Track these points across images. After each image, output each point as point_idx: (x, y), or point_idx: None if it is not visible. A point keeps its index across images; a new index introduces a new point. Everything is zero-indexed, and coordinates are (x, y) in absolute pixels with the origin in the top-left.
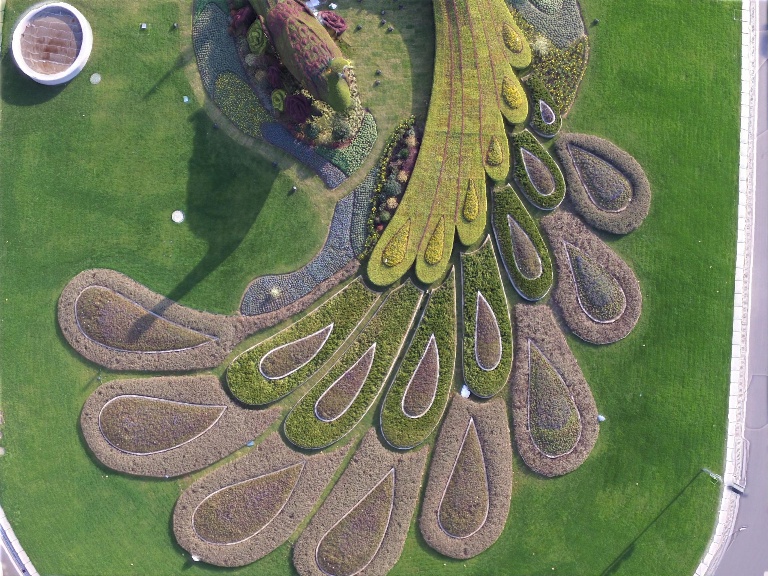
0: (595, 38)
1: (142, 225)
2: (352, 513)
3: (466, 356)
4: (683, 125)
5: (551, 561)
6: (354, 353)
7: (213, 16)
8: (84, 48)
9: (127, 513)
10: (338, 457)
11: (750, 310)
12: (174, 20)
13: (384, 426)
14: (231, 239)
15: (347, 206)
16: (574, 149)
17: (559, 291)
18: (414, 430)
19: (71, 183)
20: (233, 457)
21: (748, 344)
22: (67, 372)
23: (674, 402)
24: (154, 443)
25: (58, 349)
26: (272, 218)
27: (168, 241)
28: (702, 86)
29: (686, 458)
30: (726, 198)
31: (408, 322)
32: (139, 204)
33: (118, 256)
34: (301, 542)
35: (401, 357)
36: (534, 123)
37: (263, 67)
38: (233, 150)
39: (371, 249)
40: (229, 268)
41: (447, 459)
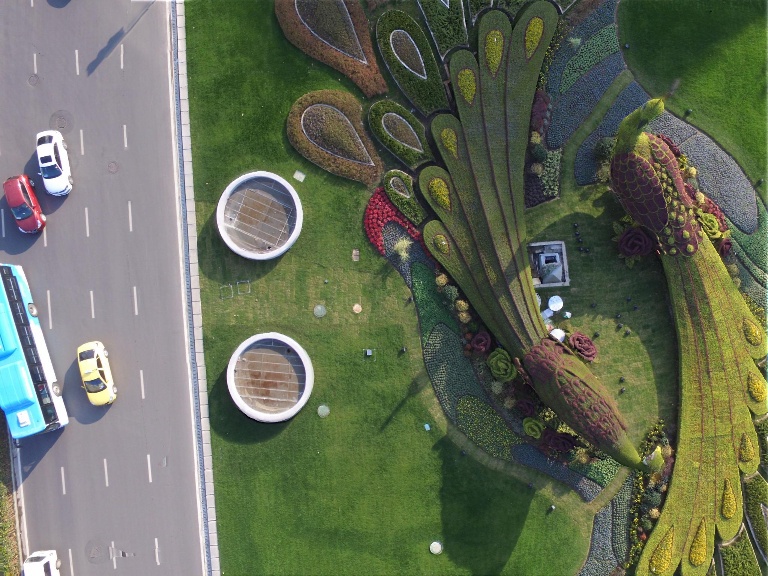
0: None
1: (400, 560)
2: None
3: None
4: None
5: None
6: None
7: (445, 339)
8: (309, 383)
9: None
10: None
11: None
12: (402, 344)
13: None
14: (494, 564)
15: (606, 517)
16: None
17: None
18: None
19: (315, 523)
20: None
21: None
22: None
23: None
24: None
25: None
26: (533, 539)
27: (429, 573)
28: None
29: None
30: None
31: None
32: (393, 540)
33: None
34: None
35: None
36: None
37: (511, 394)
38: (485, 476)
39: (636, 558)
40: None
41: None
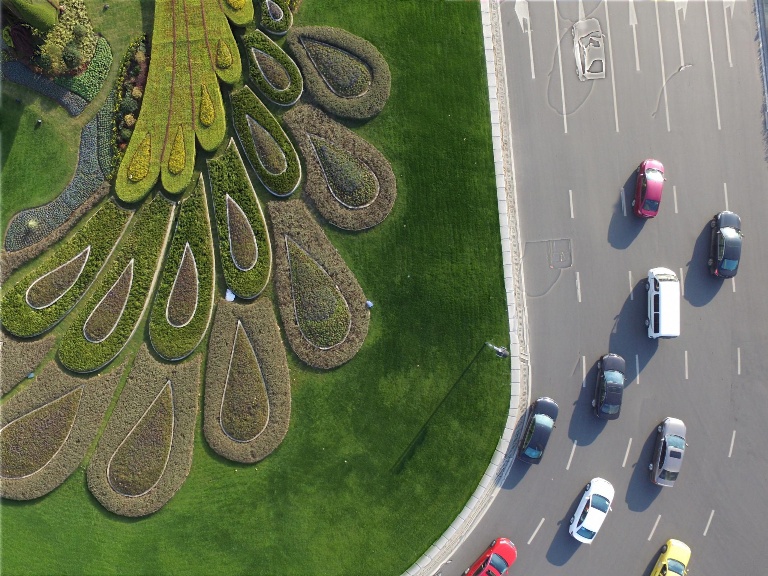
0: None
1: None
2: (135, 430)
3: (223, 259)
4: (418, 3)
5: (342, 454)
6: (113, 272)
7: None
8: None
9: None
10: (114, 377)
11: (515, 178)
12: None
13: (152, 339)
14: None
15: (91, 131)
16: (307, 42)
17: (308, 183)
18: (181, 339)
19: None
20: (17, 391)
21: (517, 212)
22: None
23: (445, 279)
24: None
25: None
26: (23, 154)
27: None
28: None
29: (466, 334)
30: (473, 69)
31: (162, 234)
32: None
33: None
34: (91, 465)
35: (163, 270)
36: (263, 22)
37: None
38: None
39: (117, 168)
40: None
41: (219, 364)
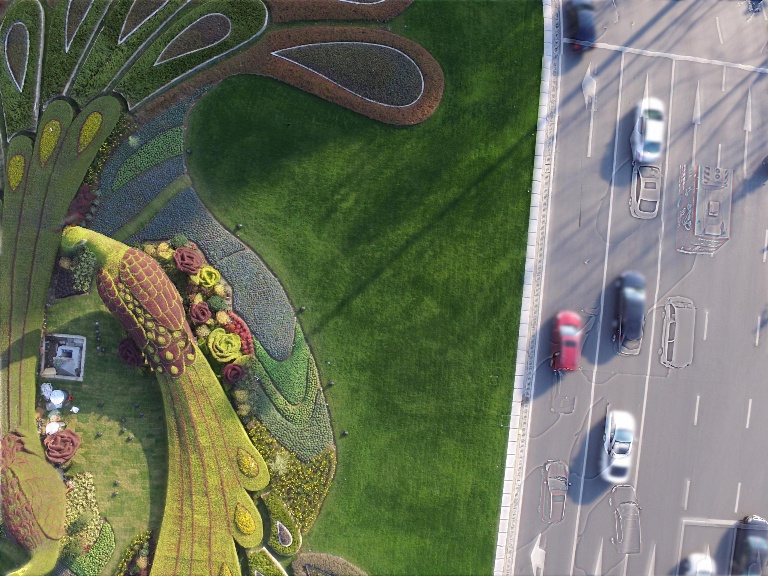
0: (344, 451)
1: None
2: None
3: None
4: (433, 543)
5: None
6: None
7: None
8: None
9: None
10: None
11: None
12: None
13: None
14: None
15: None
16: (312, 570)
17: None
18: None
19: None
20: None
21: None
22: None
23: None
24: None
25: None
26: None
27: None
28: (457, 501)
29: None
30: None
31: None
32: None
33: None
34: None
35: None
36: (271, 544)
37: None
38: None
39: None
40: None
41: None
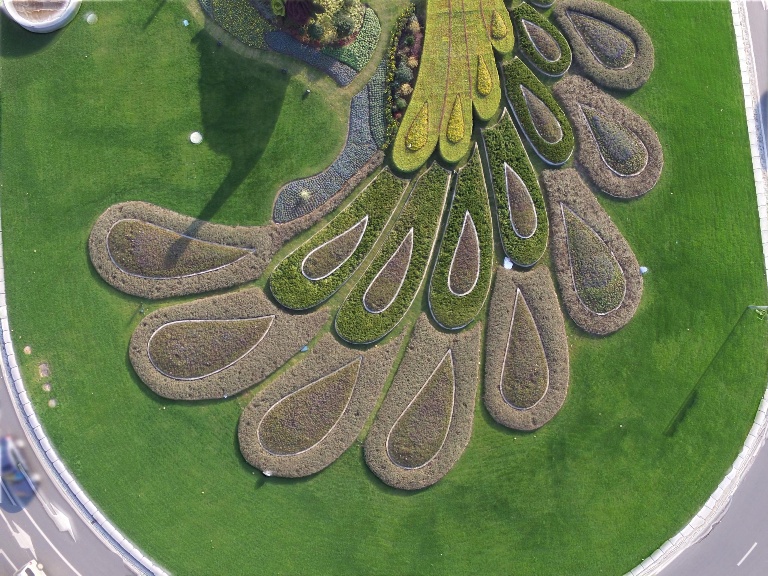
0: None
1: (162, 152)
2: (416, 401)
3: (503, 227)
4: None
5: (618, 419)
6: (393, 241)
7: None
8: None
9: (190, 441)
10: (393, 347)
11: (766, 147)
12: None
13: (434, 308)
14: (253, 151)
15: (363, 101)
16: (573, 14)
17: (582, 152)
18: (464, 307)
19: (84, 124)
20: (289, 366)
21: None
22: (108, 311)
23: (710, 245)
24: (207, 365)
25: (95, 290)
26: (291, 124)
27: (190, 164)
28: None
29: (730, 298)
30: (725, 43)
31: (441, 203)
32: (156, 132)
33: (142, 187)
34: (370, 438)
35: (439, 239)
36: None
37: None
38: (241, 64)
39: (393, 138)
40: (256, 179)
41: (501, 332)
